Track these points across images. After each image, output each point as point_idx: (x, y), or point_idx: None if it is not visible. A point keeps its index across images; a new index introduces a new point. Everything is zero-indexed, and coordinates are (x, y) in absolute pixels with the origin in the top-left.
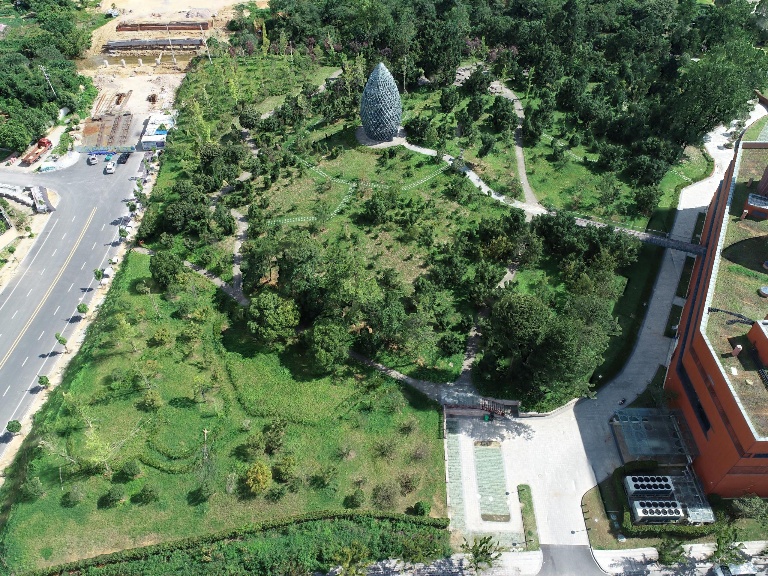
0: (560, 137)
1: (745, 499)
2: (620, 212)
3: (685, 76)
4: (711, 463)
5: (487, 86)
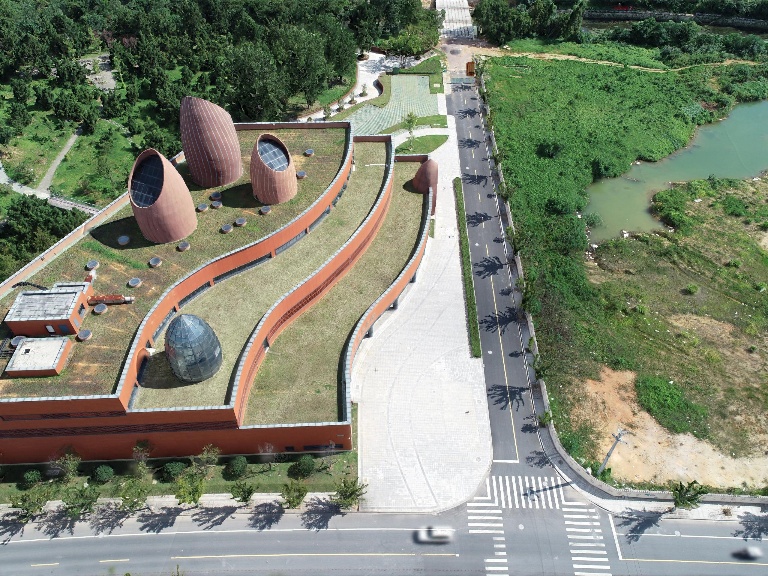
0: (128, 125)
1: None
2: None
3: None
4: None
5: (77, 76)
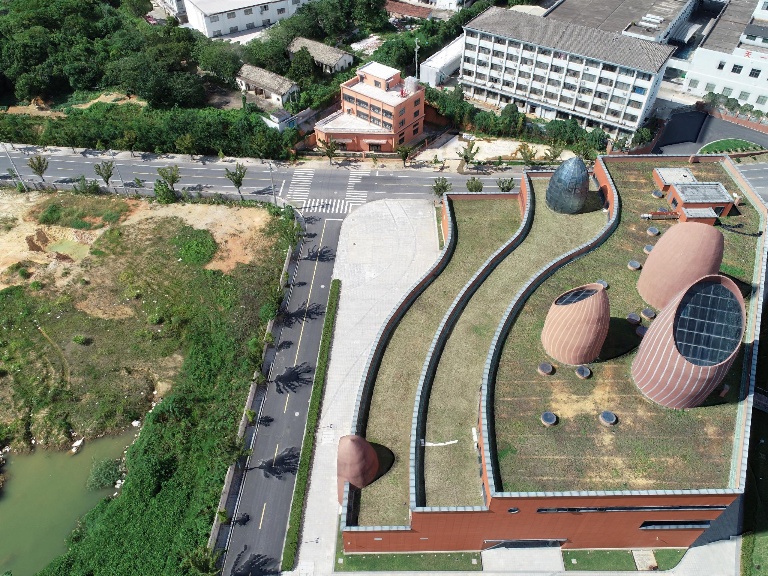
0: None
1: None
2: None
3: None
4: None
5: None
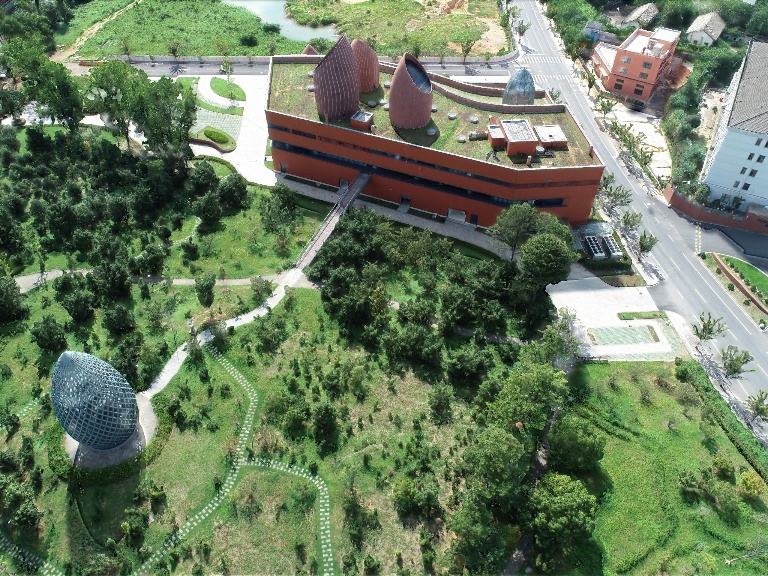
0: None
1: (597, 203)
2: (291, 221)
3: (58, 134)
4: (578, 211)
5: (18, 292)
